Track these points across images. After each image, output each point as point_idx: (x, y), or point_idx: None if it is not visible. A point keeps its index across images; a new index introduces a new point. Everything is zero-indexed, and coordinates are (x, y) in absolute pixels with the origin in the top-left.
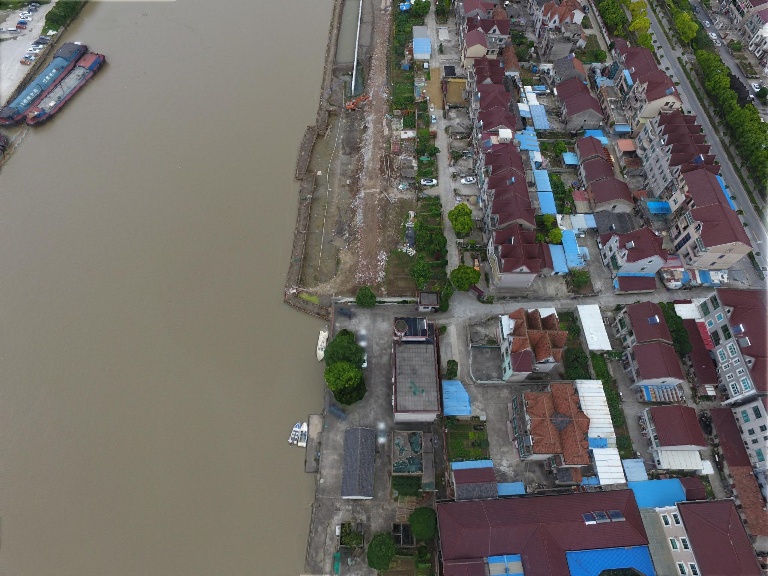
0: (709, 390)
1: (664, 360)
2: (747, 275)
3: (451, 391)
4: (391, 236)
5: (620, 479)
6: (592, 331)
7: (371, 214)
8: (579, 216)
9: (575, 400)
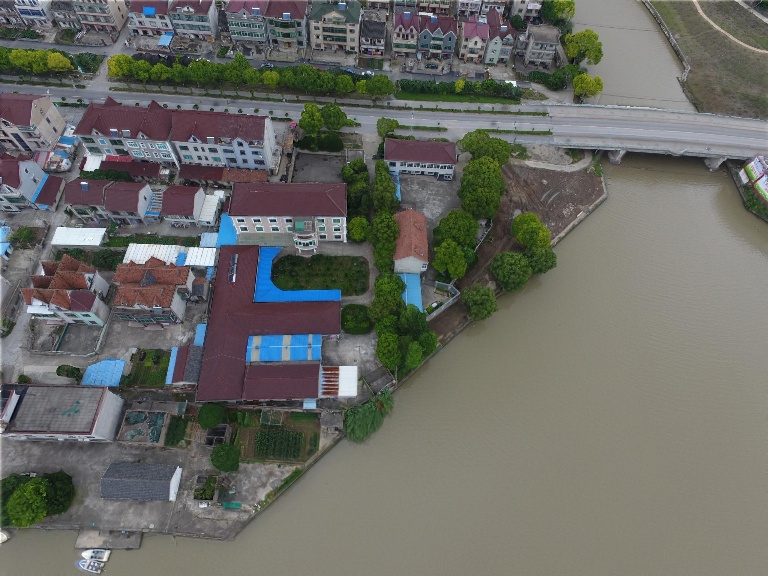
0: (164, 173)
1: (123, 191)
2: (81, 114)
3: (95, 377)
4: None
5: (213, 252)
6: (82, 239)
7: None
8: None
9: (133, 264)
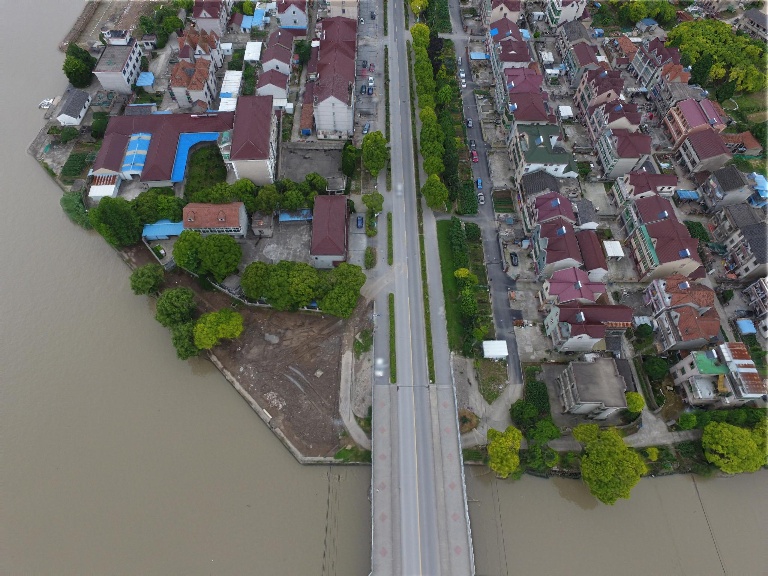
0: (312, 76)
1: (275, 52)
2: (377, 34)
3: (144, 76)
4: (141, 15)
5: (232, 109)
6: (250, 52)
7: (135, 9)
8: (273, 3)
9: (205, 64)
